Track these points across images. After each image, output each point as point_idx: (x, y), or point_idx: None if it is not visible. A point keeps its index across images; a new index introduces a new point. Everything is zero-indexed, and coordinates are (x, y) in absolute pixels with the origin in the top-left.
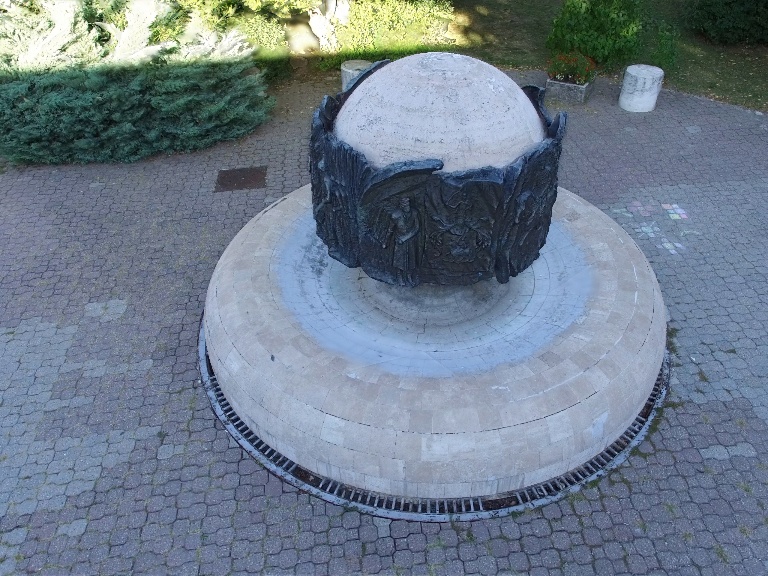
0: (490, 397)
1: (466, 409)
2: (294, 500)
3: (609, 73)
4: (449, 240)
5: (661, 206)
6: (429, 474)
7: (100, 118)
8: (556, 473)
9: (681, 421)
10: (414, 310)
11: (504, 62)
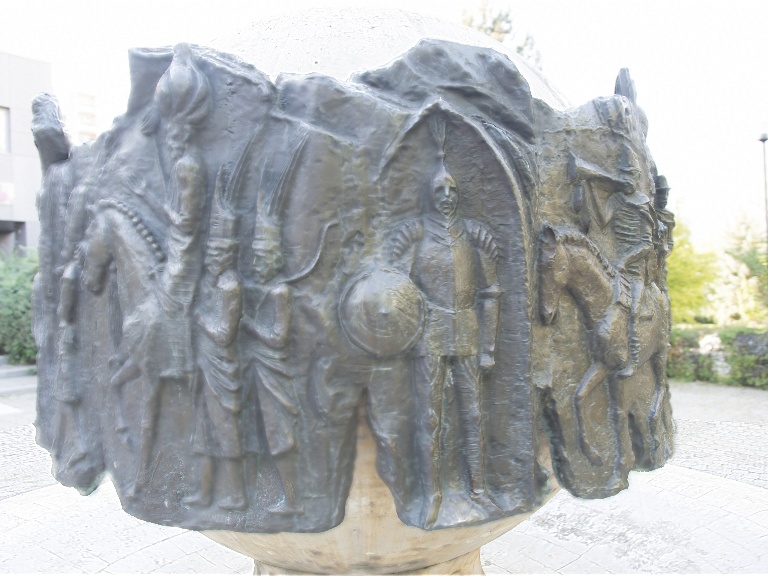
0: None
1: None
2: None
3: None
4: None
5: None
6: None
7: None
8: None
9: None
10: None
11: None
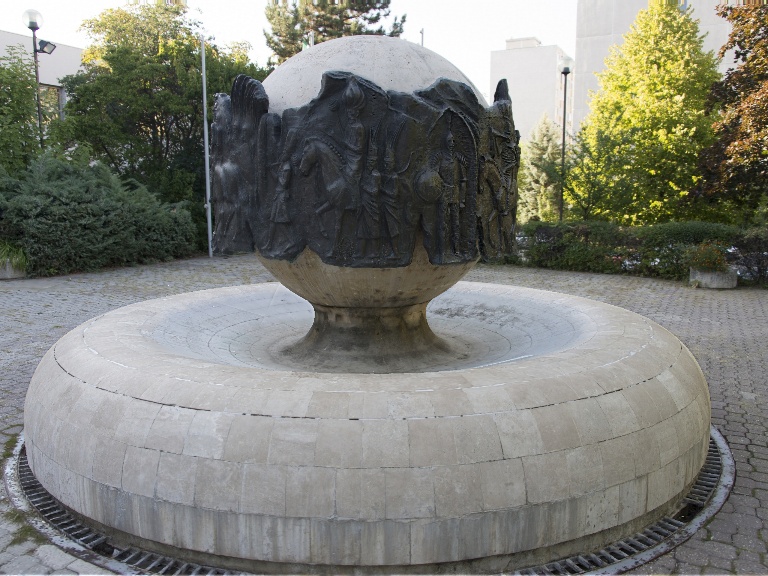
0: None
1: None
2: None
3: None
4: None
5: None
6: None
7: None
8: None
9: None
10: None
11: None
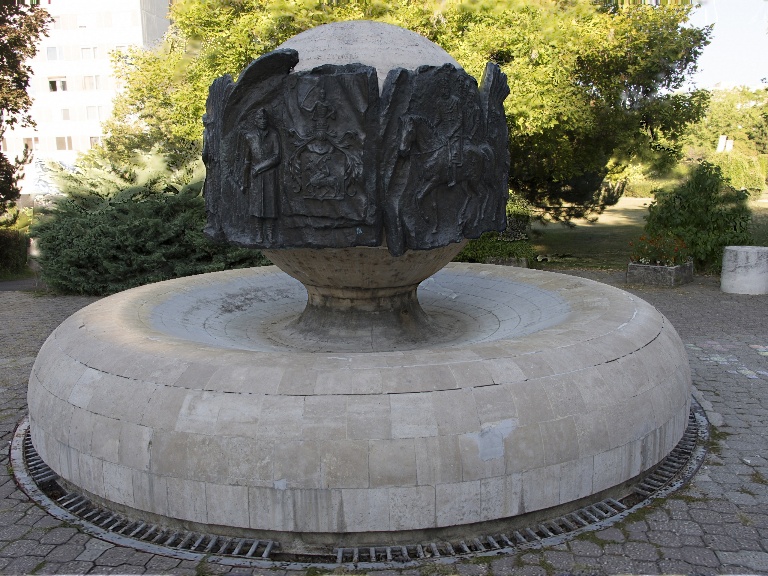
0: (315, 362)
1: (270, 368)
2: (9, 506)
3: (717, 273)
4: (307, 162)
5: (748, 346)
6: (182, 458)
7: (132, 242)
8: (410, 517)
9: (694, 516)
10: (313, 340)
11: (592, 266)
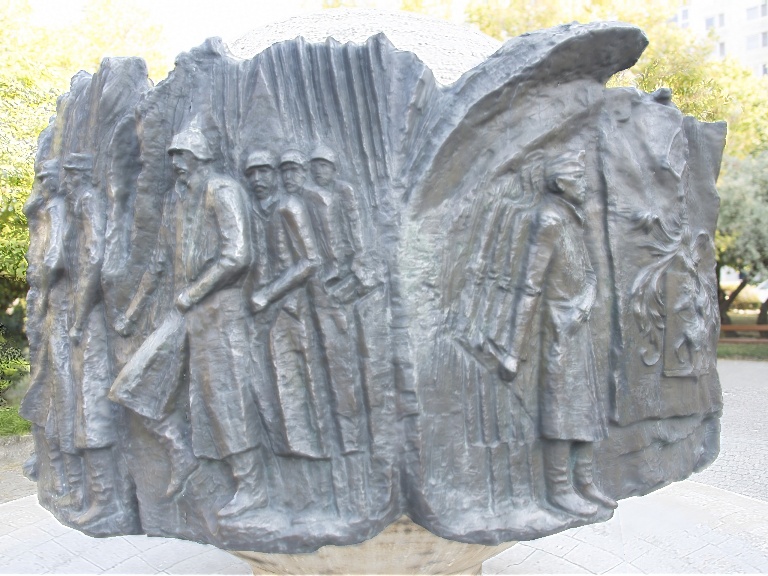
0: None
1: None
2: None
3: None
4: (679, 292)
5: None
6: None
7: None
8: None
9: None
10: None
11: None
